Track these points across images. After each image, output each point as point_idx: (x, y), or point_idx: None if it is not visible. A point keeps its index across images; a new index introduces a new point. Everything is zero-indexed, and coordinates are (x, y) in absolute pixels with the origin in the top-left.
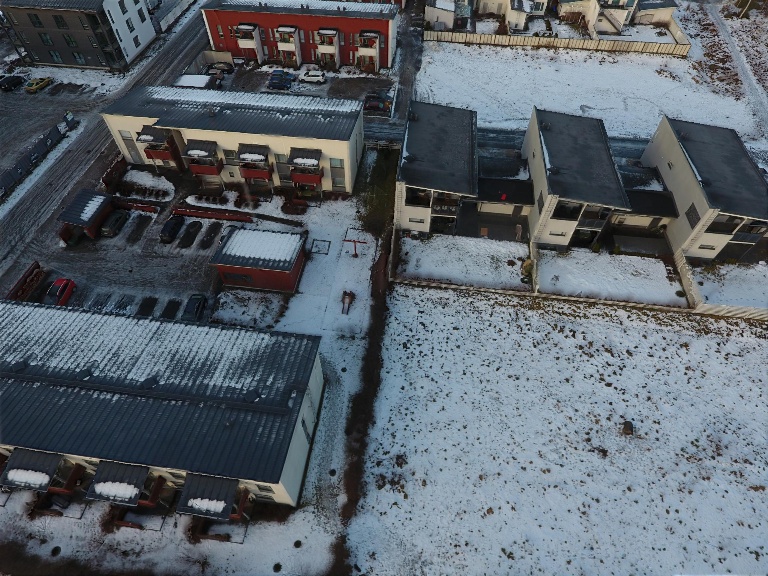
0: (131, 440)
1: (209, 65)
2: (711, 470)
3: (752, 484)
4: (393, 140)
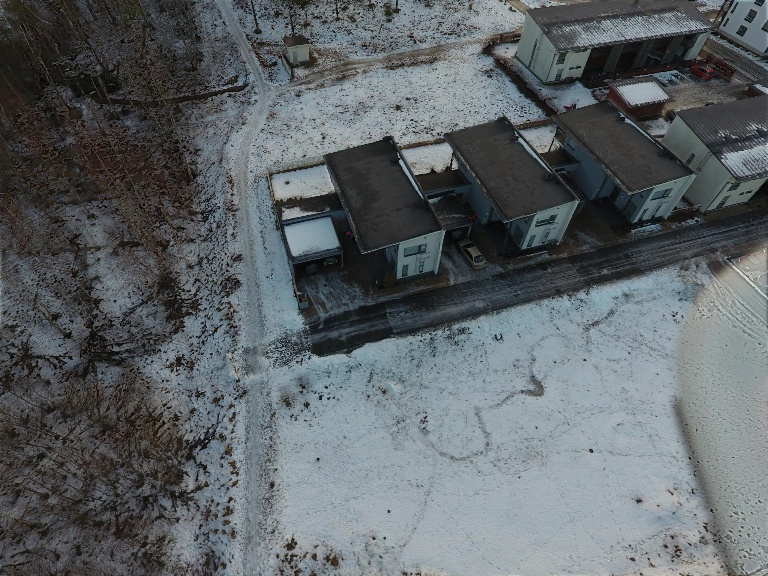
0: (581, 7)
1: None
2: (359, 106)
3: (341, 107)
4: (686, 228)
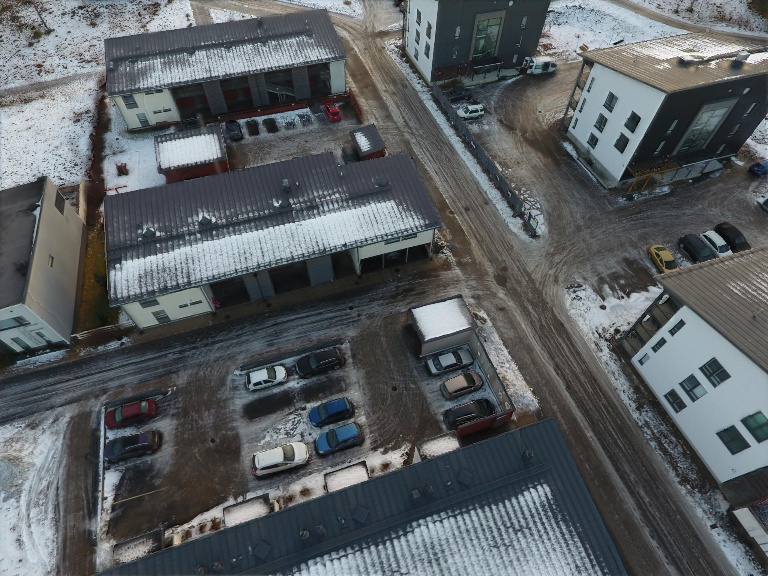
0: (180, 34)
1: (494, 411)
2: None
3: None
4: (96, 356)
